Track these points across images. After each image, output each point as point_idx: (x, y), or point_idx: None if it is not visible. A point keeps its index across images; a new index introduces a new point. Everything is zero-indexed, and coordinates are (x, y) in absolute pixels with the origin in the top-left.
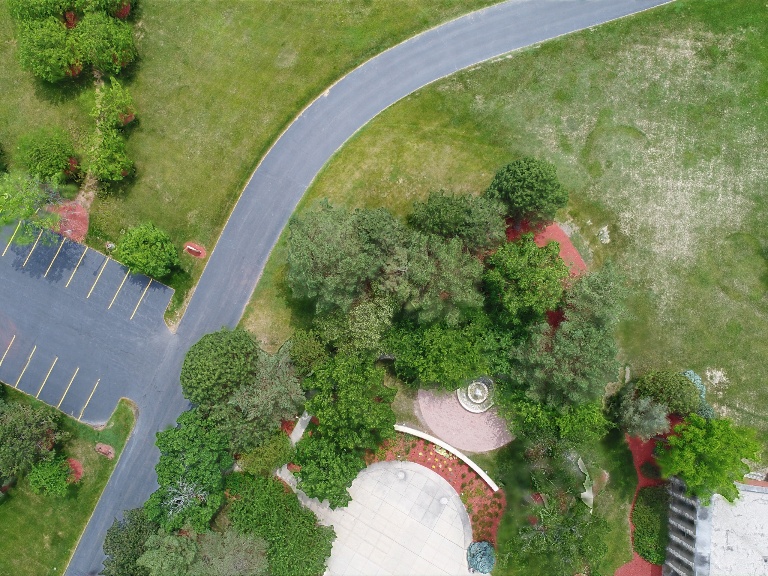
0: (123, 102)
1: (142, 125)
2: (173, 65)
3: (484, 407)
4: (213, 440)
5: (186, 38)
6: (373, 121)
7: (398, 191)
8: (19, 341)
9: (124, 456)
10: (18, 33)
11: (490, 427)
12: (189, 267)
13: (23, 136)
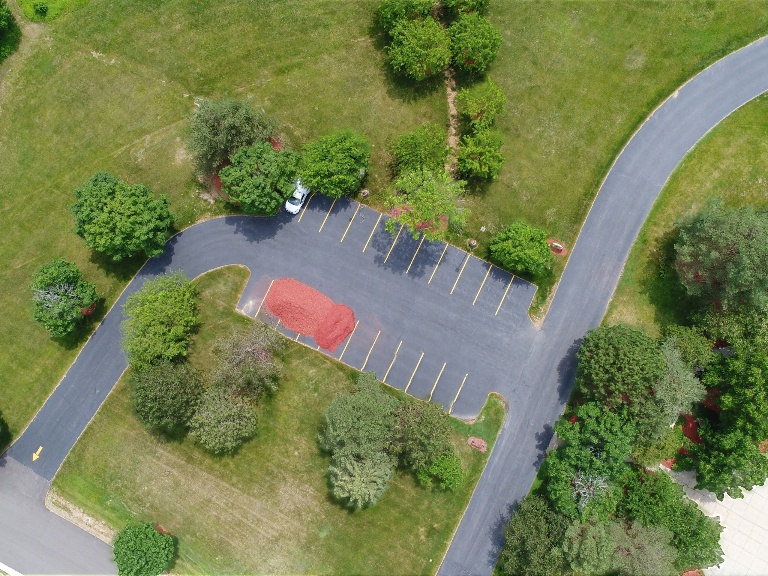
0: (503, 101)
1: (496, 124)
2: (522, 65)
3: None
4: (628, 433)
5: (533, 39)
6: (724, 122)
7: (757, 191)
8: (385, 337)
9: (496, 450)
10: (380, 32)
11: None
12: (551, 264)
13: (377, 134)
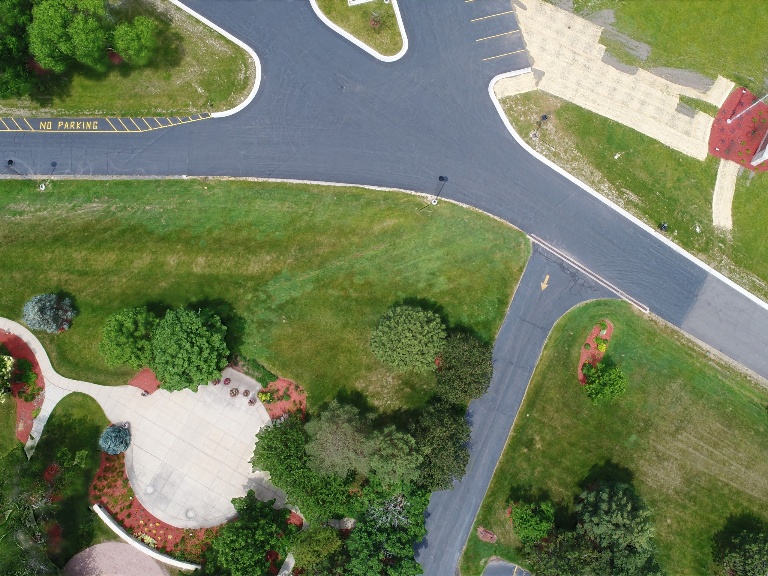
0: None
1: None
2: None
3: None
4: None
5: None
6: None
7: None
8: None
9: (467, 529)
10: None
11: (98, 568)
12: None
13: None
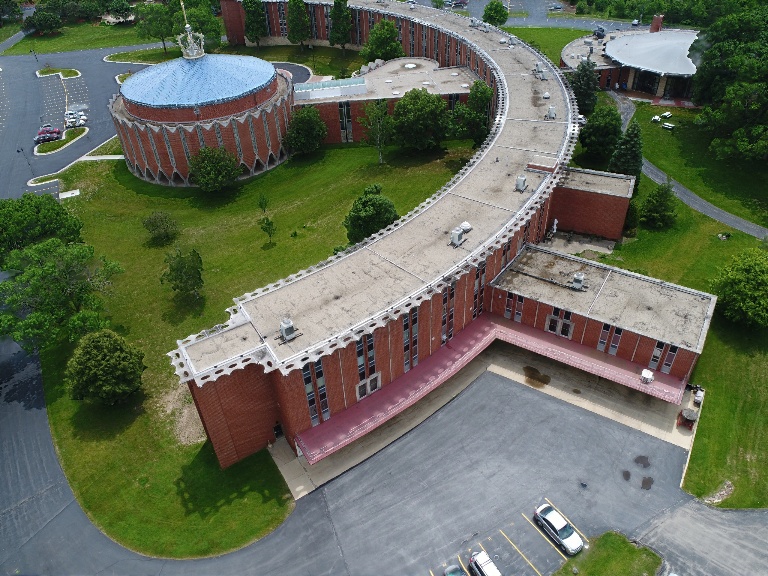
0: None
1: None
2: None
3: (152, 2)
4: None
5: None
6: None
7: None
8: None
9: None
10: None
11: None
12: None
13: None
